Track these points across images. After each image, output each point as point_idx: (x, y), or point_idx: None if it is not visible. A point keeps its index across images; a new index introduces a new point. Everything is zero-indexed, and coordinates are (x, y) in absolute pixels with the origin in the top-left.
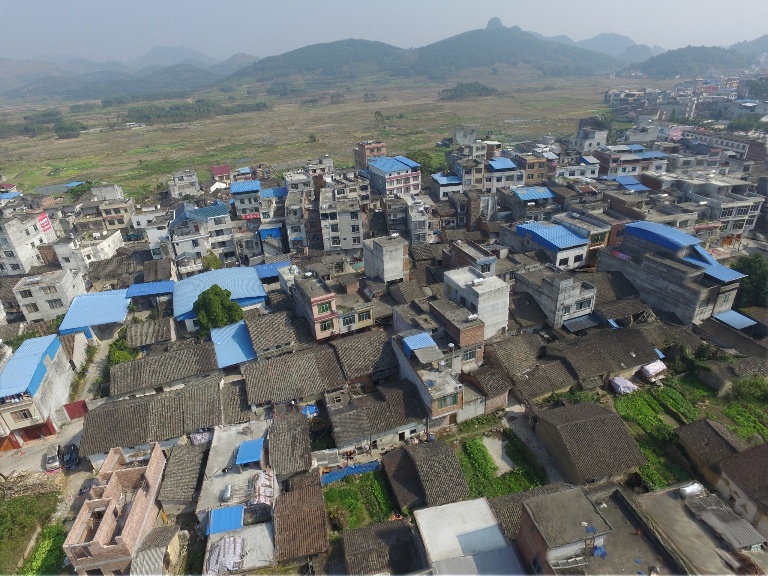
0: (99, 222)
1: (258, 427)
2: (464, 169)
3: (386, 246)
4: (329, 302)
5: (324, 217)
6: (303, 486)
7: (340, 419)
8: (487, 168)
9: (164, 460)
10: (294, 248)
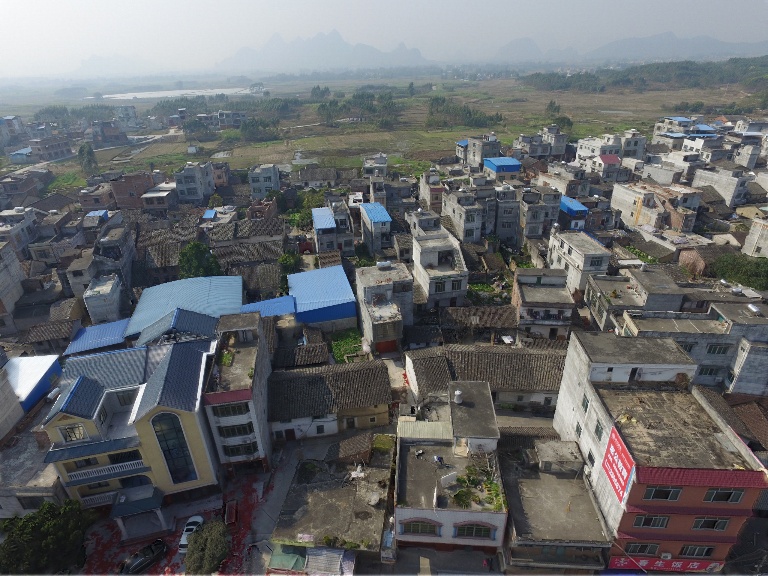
0: None
1: None
2: None
3: None
4: None
5: None
6: None
7: None
8: None
9: None
10: None
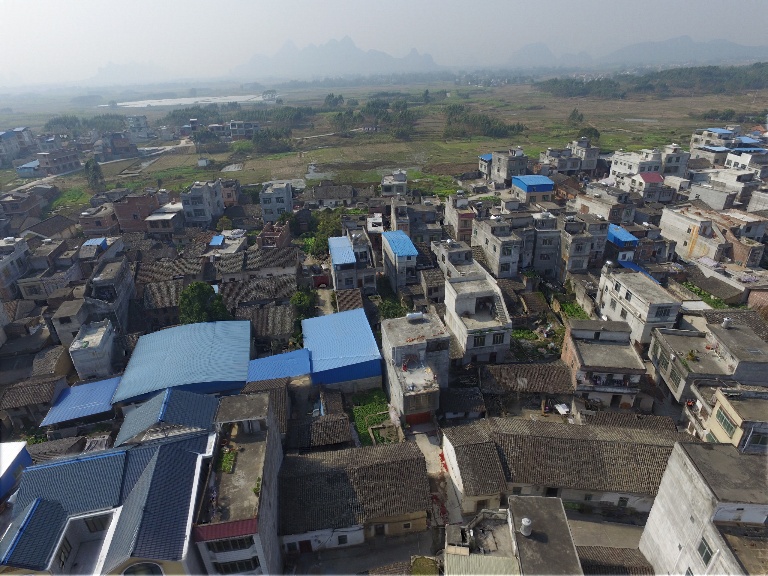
0: None
1: (210, 254)
2: None
3: None
4: None
5: None
6: None
7: None
8: None
9: None
10: None
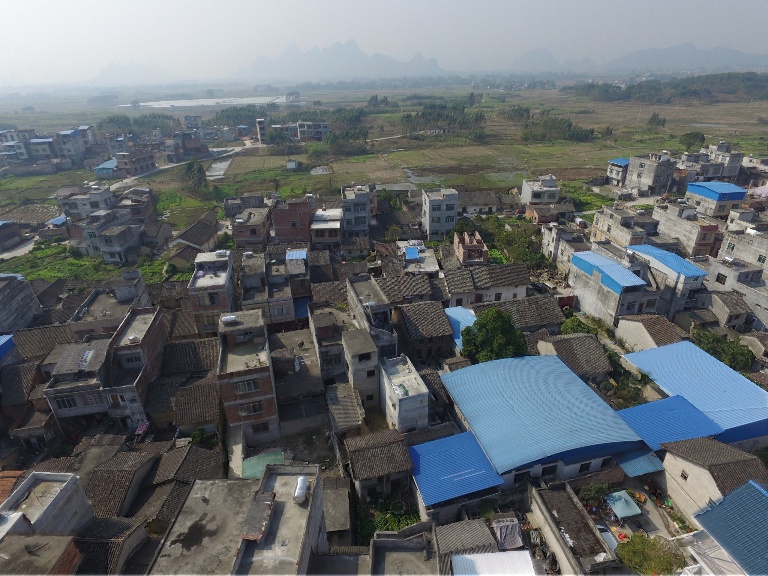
0: None
1: (413, 269)
2: None
3: None
4: None
5: None
6: None
7: None
8: None
9: (462, 263)
10: None
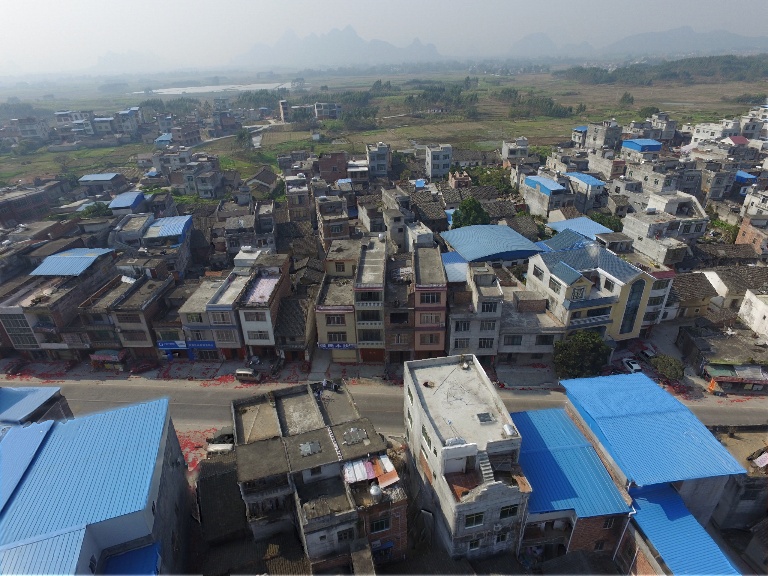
0: None
1: None
2: None
3: None
4: None
5: None
6: None
7: None
8: None
9: None
10: None
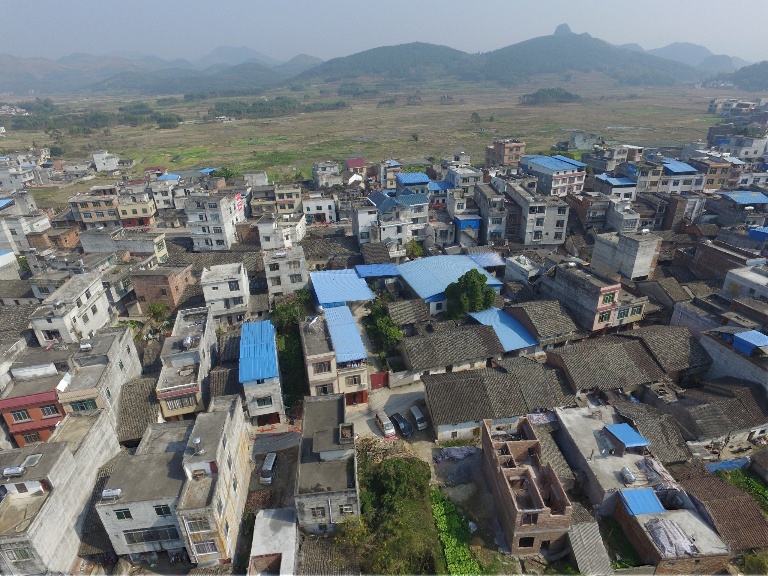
0: (272, 206)
1: (602, 412)
2: (641, 170)
3: (643, 241)
4: (613, 293)
5: (531, 210)
6: (691, 476)
7: (697, 411)
8: (666, 171)
9: None
10: (491, 240)
